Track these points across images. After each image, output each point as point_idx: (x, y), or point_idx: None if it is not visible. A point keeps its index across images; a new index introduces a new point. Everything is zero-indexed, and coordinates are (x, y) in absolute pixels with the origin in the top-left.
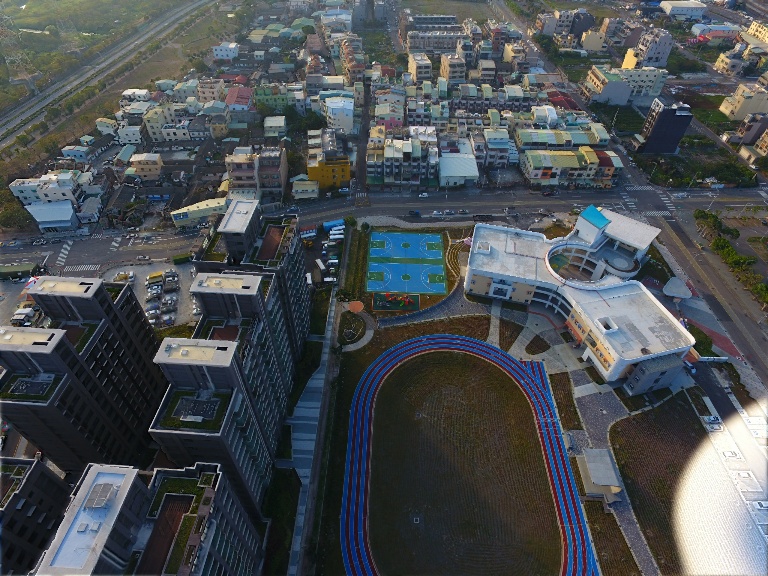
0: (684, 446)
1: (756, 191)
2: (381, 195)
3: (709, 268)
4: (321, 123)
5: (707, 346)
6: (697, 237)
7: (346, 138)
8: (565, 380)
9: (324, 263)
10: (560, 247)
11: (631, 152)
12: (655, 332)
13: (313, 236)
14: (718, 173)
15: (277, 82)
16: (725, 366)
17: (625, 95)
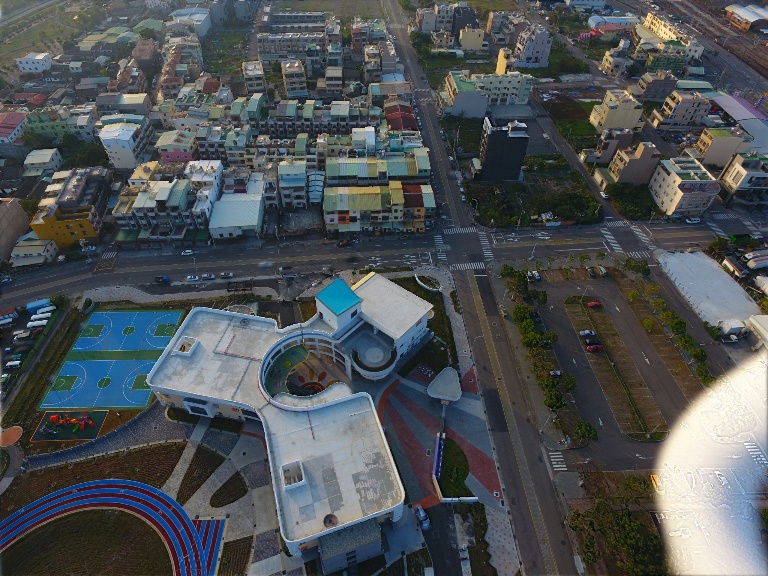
0: None
1: (598, 228)
2: (134, 254)
3: (505, 346)
4: (102, 155)
5: (460, 476)
6: (505, 299)
7: (105, 180)
8: (243, 551)
9: (3, 365)
10: (292, 339)
11: (465, 181)
12: (358, 482)
13: (8, 323)
14: (560, 205)
15: (85, 100)
16: (473, 510)
17: (481, 106)
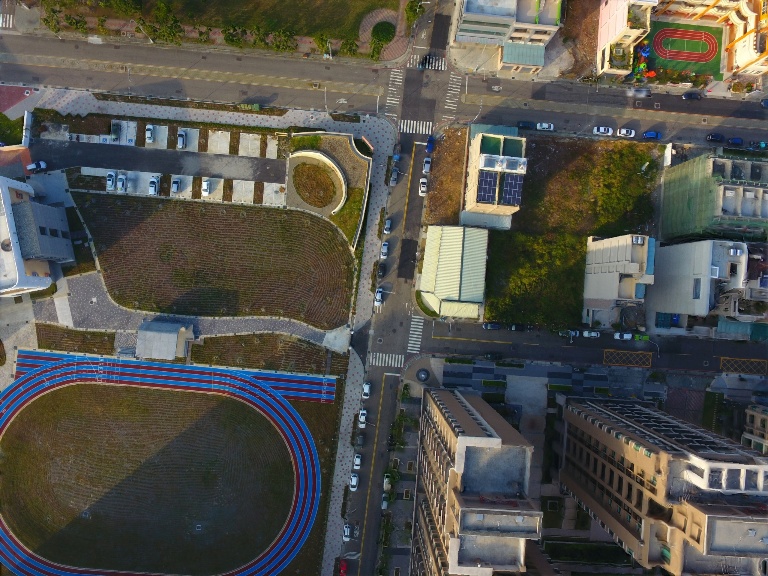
0: (141, 230)
1: None
2: None
3: None
4: None
5: (5, 123)
6: None
7: None
8: (48, 331)
9: None
10: None
11: None
12: None
13: None
14: None
15: None
16: (38, 119)
17: None
